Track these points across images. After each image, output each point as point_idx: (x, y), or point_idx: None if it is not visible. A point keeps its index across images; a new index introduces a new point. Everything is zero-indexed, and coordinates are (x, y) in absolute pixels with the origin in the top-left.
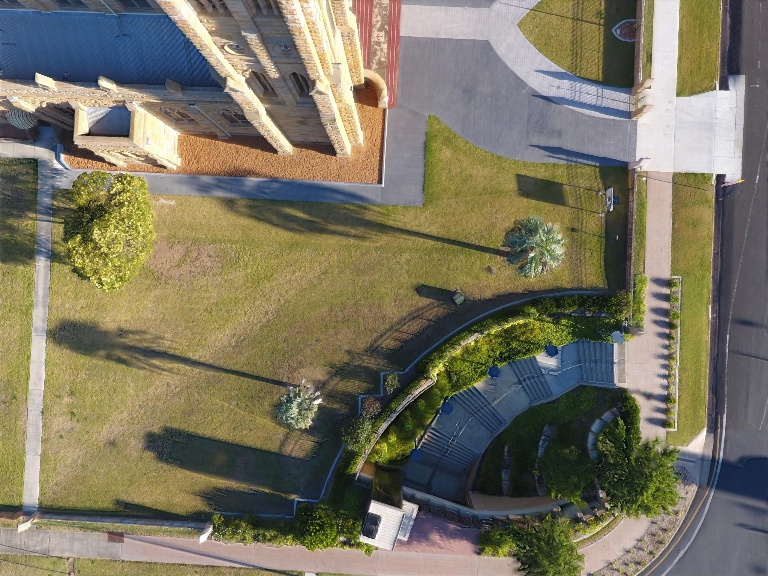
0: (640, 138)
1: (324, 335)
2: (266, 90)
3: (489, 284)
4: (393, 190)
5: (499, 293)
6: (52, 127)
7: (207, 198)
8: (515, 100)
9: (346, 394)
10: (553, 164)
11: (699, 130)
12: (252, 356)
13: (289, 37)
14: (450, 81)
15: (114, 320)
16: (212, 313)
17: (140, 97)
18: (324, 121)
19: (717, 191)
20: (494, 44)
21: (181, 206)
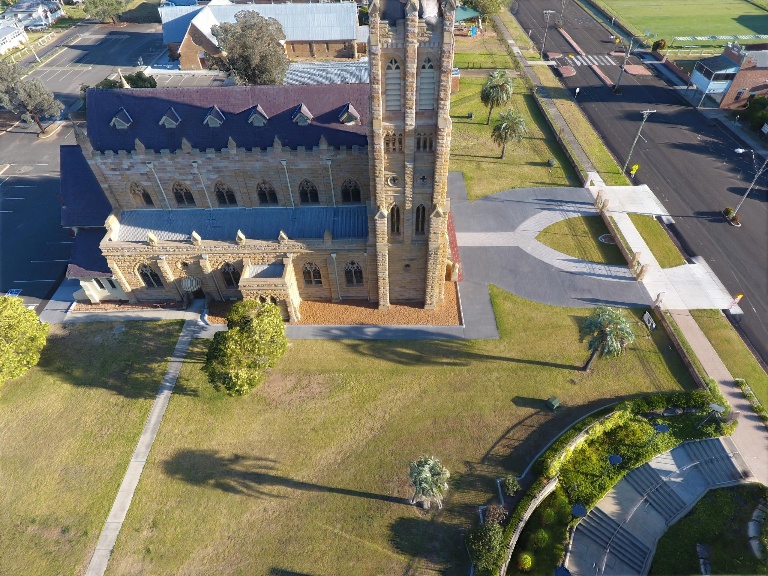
0: (650, 291)
1: (431, 446)
2: (393, 232)
3: (577, 393)
4: (473, 329)
5: (589, 400)
6: (207, 296)
7: (320, 340)
8: (549, 274)
9: (464, 506)
10: (593, 308)
11: (690, 285)
12: (359, 471)
13: (429, 169)
14: (499, 266)
15: (220, 443)
16: (318, 432)
17: (299, 248)
18: (431, 249)
19: (730, 320)
20: (523, 248)
21: (297, 347)
